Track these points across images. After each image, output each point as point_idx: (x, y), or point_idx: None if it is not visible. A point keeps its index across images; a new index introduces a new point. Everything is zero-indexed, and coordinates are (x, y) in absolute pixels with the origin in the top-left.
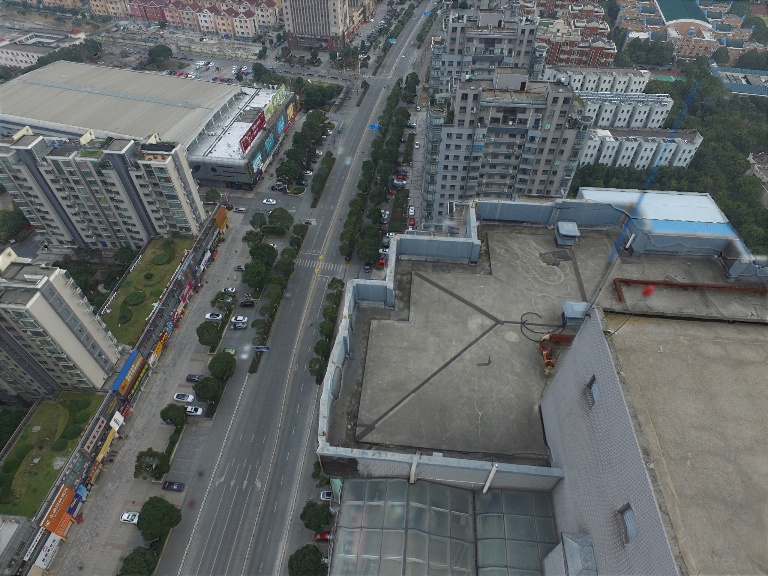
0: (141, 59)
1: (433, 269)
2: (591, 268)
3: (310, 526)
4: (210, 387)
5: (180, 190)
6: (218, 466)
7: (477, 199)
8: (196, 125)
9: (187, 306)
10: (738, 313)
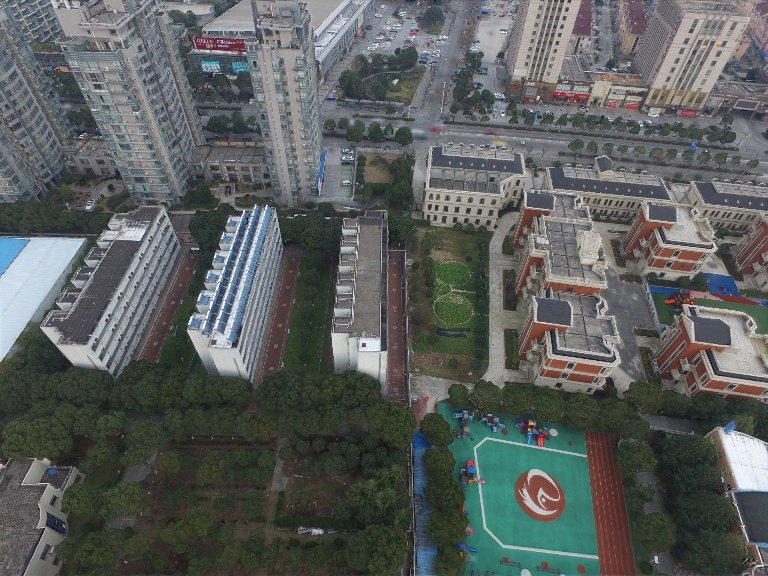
0: None
1: None
2: None
3: None
4: None
5: None
6: None
7: None
8: None
9: None
10: None
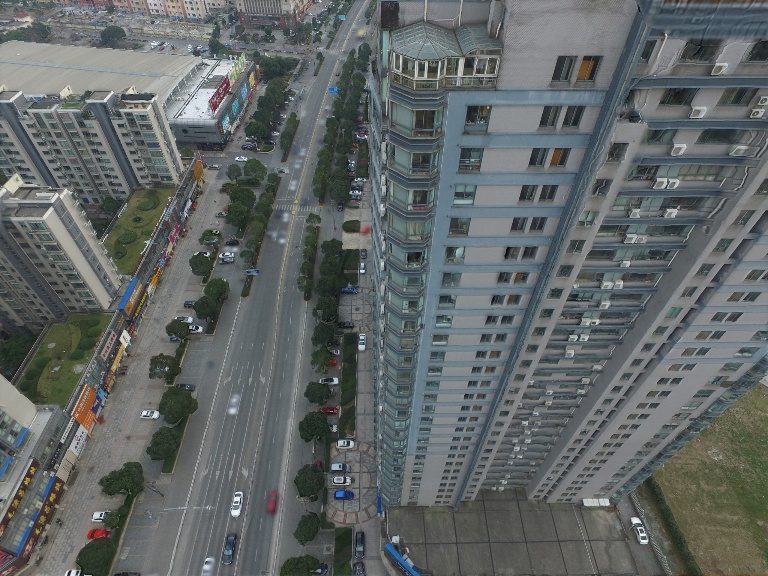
0: (93, 41)
1: None
2: None
3: (314, 399)
4: (210, 303)
5: (160, 139)
6: (224, 370)
7: None
8: (163, 91)
9: (175, 248)
10: None
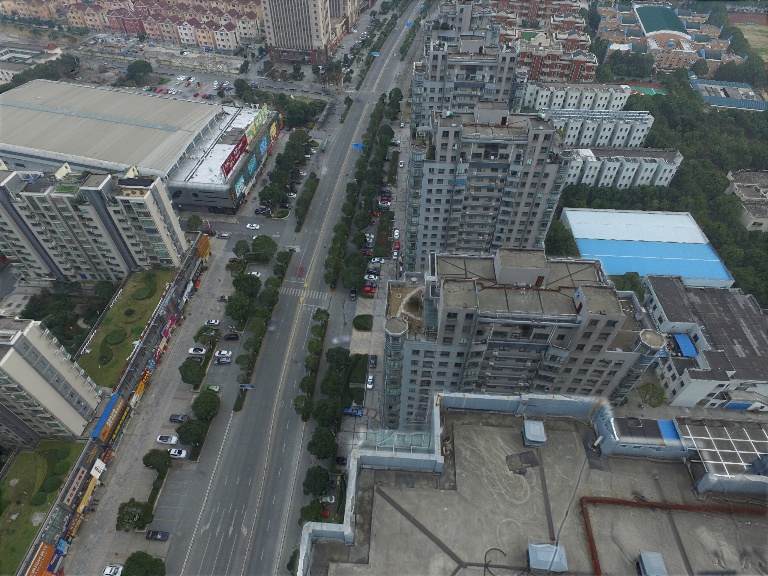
0: (120, 74)
1: (396, 481)
2: (558, 477)
3: None
4: (193, 431)
5: (160, 223)
6: (203, 512)
7: (461, 230)
8: (176, 149)
9: (170, 340)
10: (705, 561)
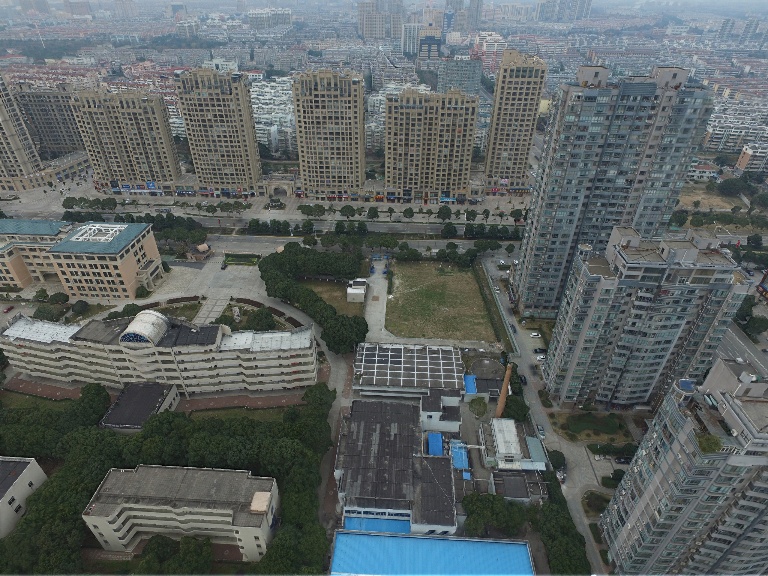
0: None
1: None
2: None
3: None
4: None
5: None
6: None
7: None
8: None
9: None
10: (665, 87)
